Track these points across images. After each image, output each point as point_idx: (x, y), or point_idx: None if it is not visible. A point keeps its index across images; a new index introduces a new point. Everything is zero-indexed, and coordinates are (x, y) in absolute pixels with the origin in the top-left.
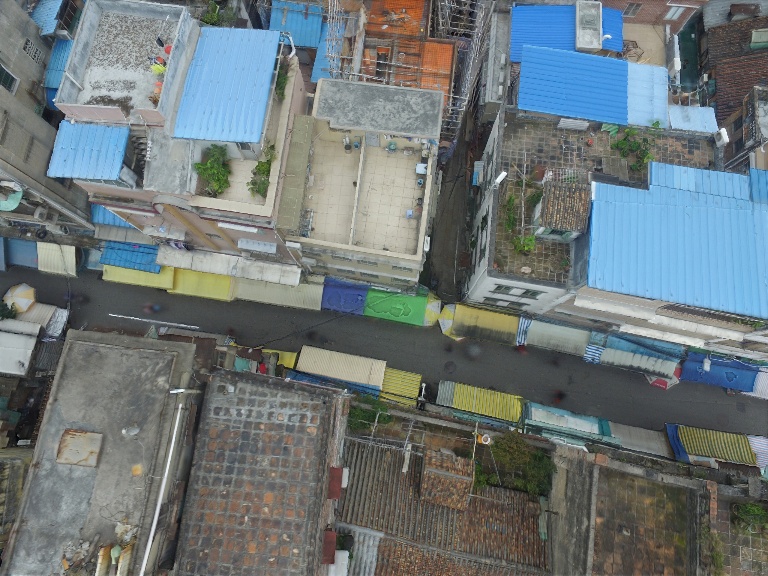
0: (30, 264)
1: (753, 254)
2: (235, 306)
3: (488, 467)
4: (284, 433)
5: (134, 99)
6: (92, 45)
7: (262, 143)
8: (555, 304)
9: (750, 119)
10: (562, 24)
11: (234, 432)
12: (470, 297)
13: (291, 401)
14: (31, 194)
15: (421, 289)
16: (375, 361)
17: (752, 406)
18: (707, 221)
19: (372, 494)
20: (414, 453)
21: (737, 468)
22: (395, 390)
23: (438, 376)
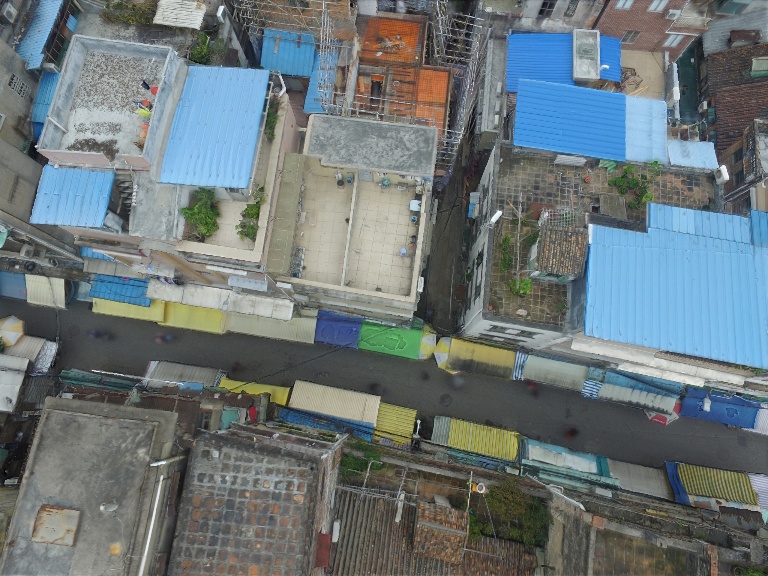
0: (19, 296)
1: (754, 301)
2: (228, 337)
3: (483, 515)
4: (270, 501)
5: (119, 142)
6: (77, 86)
7: (250, 188)
8: (552, 343)
9: (751, 153)
10: (559, 53)
11: (218, 500)
12: (466, 332)
13: (277, 467)
14: (17, 233)
15: (416, 322)
16: (369, 396)
17: (753, 440)
18: (707, 266)
19: (364, 546)
20: (407, 503)
21: (738, 513)
22: (389, 426)
23: (434, 409)
